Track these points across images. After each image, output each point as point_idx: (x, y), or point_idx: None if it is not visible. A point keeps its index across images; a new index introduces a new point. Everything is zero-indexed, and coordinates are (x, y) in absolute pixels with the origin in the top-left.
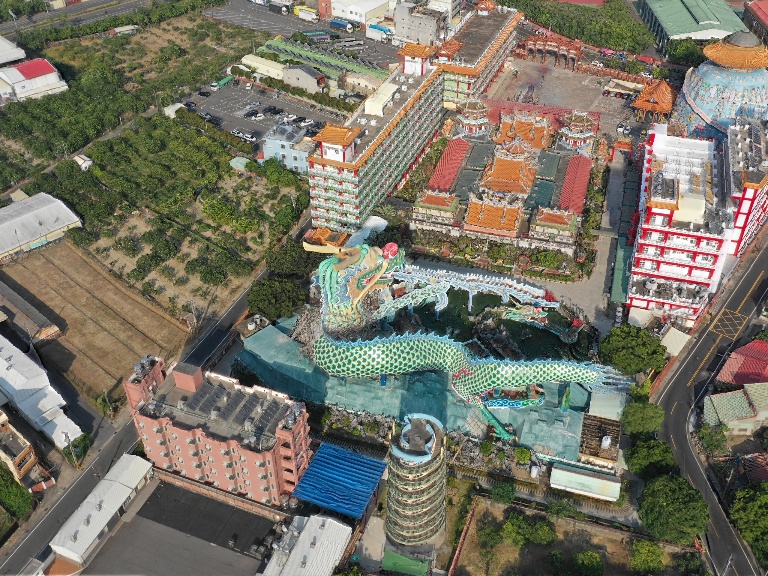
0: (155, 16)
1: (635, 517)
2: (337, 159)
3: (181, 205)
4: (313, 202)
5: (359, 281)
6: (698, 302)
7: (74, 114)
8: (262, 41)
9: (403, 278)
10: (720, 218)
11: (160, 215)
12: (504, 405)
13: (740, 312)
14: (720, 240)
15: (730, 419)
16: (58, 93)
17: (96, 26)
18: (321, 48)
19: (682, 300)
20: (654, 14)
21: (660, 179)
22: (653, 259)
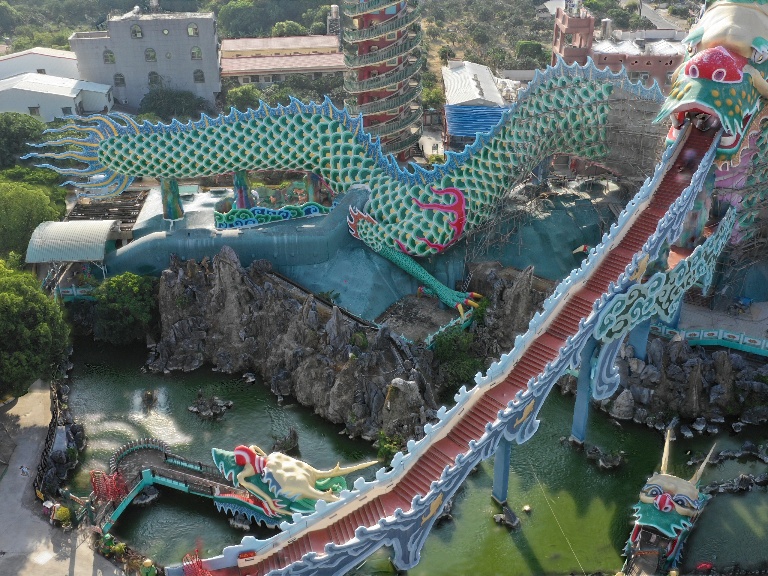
0: None
1: (72, 204)
2: None
3: None
4: None
5: None
6: None
7: None
8: None
9: None
10: None
11: None
12: None
13: None
14: None
15: None
16: None
17: None
18: None
19: None
20: None
21: None
22: None
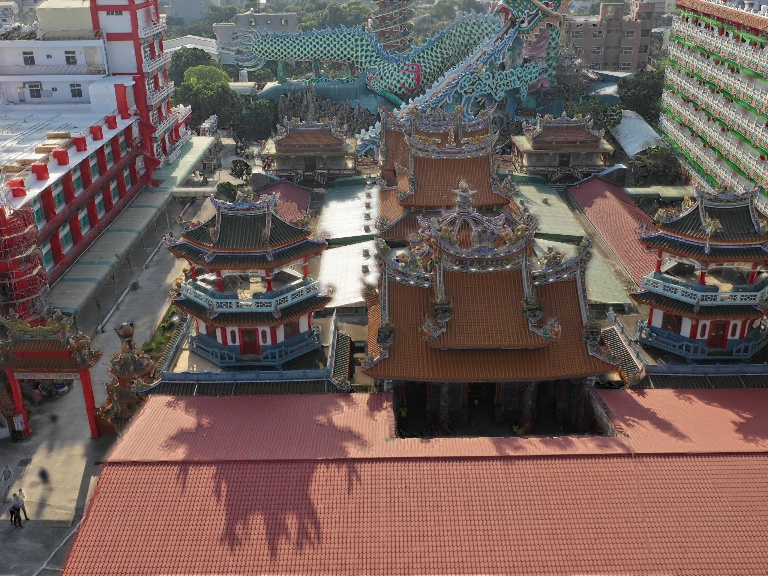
0: None
1: None
2: None
3: None
4: None
5: None
6: None
7: None
8: None
9: None
10: None
11: None
12: None
13: None
14: None
15: None
16: None
17: None
18: None
19: None
20: None
21: None
22: None
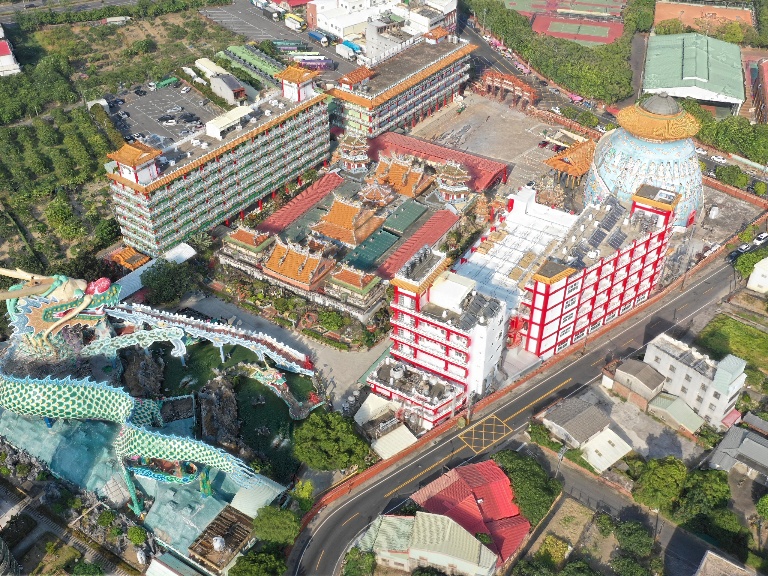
0: (151, 10)
1: None
2: (132, 179)
3: (31, 202)
4: (120, 219)
5: (47, 313)
6: (436, 402)
7: (6, 98)
8: (235, 45)
9: (122, 316)
10: (481, 311)
11: (7, 209)
12: (150, 476)
13: (508, 422)
14: (466, 336)
15: (382, 548)
16: (7, 75)
17: (91, 14)
18: (274, 59)
19: (421, 396)
20: (645, 62)
21: (416, 255)
22: (407, 343)
